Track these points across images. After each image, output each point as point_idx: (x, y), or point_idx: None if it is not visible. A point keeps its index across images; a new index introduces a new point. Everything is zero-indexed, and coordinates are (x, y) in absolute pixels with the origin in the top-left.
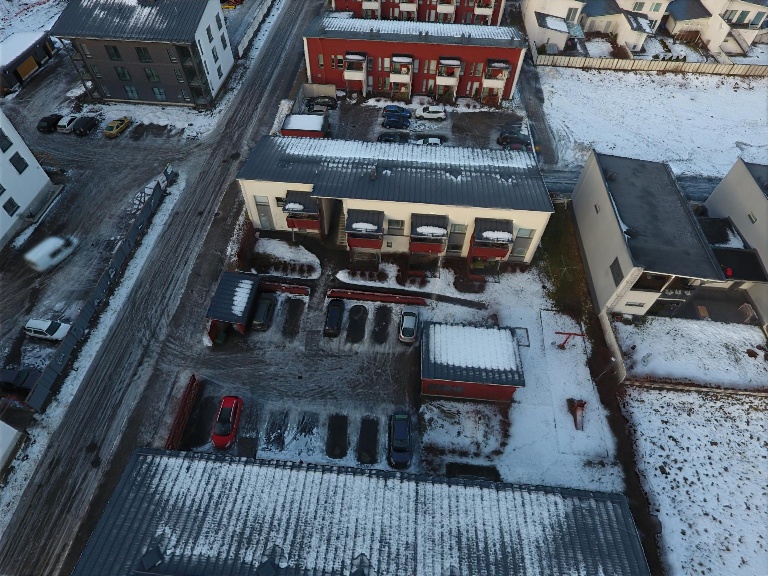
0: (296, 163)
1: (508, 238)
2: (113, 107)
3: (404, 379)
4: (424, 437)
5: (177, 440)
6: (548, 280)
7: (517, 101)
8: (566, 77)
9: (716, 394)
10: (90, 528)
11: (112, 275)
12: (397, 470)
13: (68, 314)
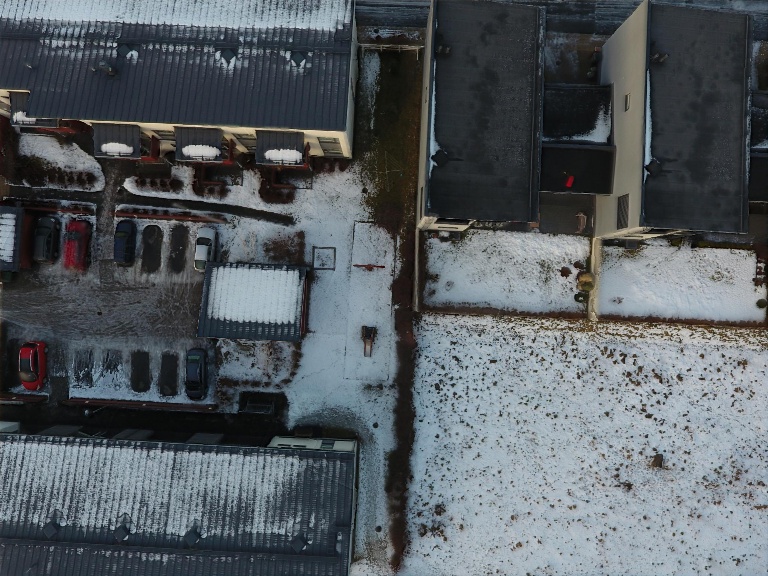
0: (5, 42)
1: (296, 159)
2: None
3: None
4: (220, 370)
5: None
6: (371, 181)
7: None
8: None
9: (510, 318)
10: None
11: None
12: (194, 401)
13: None
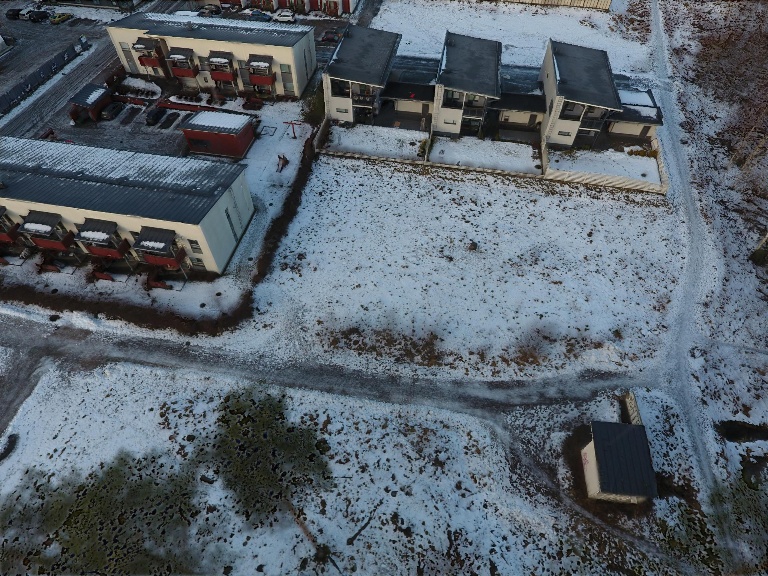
0: (148, 22)
1: (265, 66)
2: (63, 8)
3: (184, 145)
4: None
5: None
6: (307, 107)
7: (356, 15)
8: (404, 2)
9: (375, 161)
10: None
11: None
12: None
13: None
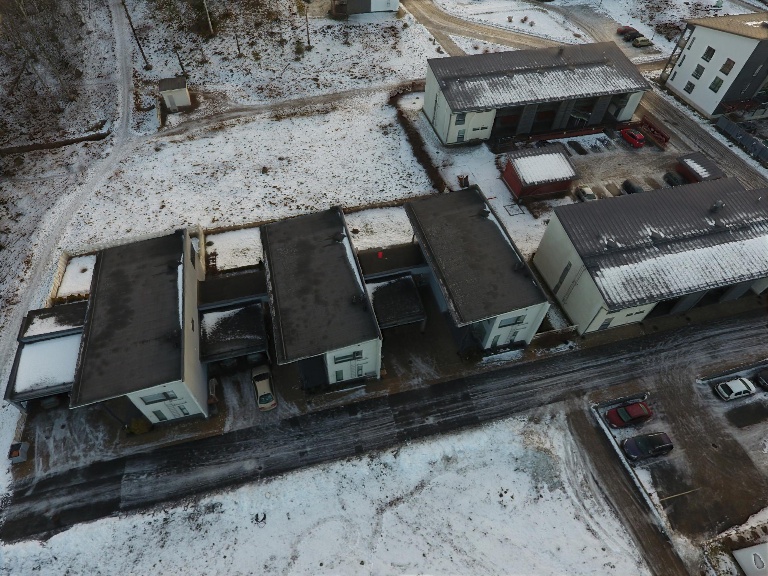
0: None
1: None
2: None
3: None
4: None
5: None
6: None
7: None
8: None
9: None
10: None
11: None
12: None
13: None
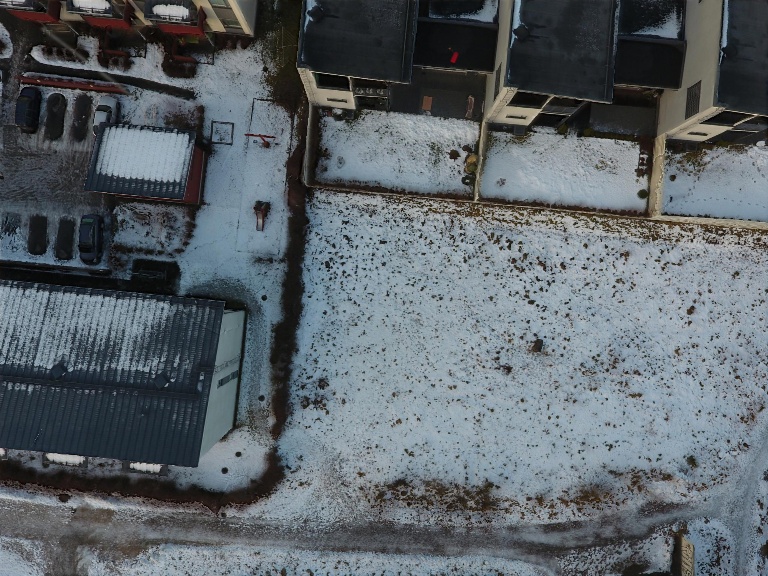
0: None
1: (182, 15)
2: None
3: None
4: (115, 237)
5: None
6: (271, 59)
7: None
8: None
9: (399, 198)
10: None
11: None
12: (88, 265)
13: None
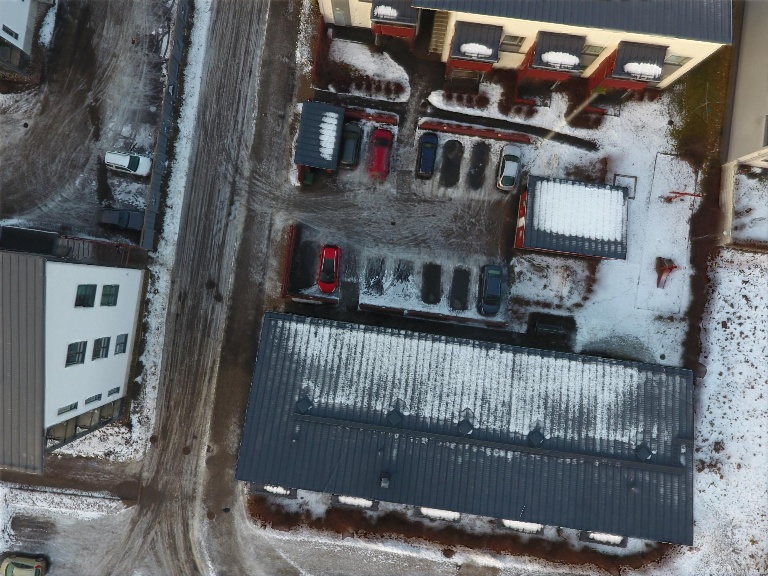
0: None
1: (655, 74)
2: None
3: (498, 230)
4: (512, 289)
5: (286, 283)
6: (678, 113)
7: None
8: None
9: None
10: (231, 349)
11: (171, 90)
12: (485, 317)
13: (140, 141)
